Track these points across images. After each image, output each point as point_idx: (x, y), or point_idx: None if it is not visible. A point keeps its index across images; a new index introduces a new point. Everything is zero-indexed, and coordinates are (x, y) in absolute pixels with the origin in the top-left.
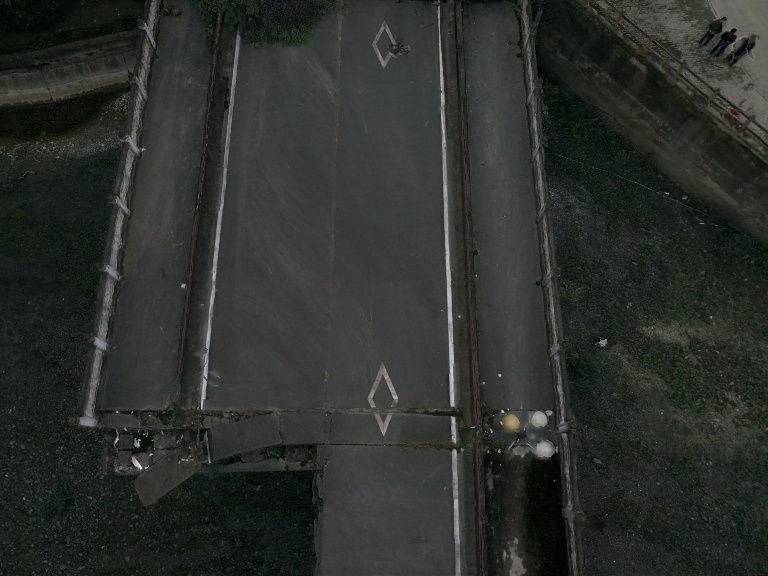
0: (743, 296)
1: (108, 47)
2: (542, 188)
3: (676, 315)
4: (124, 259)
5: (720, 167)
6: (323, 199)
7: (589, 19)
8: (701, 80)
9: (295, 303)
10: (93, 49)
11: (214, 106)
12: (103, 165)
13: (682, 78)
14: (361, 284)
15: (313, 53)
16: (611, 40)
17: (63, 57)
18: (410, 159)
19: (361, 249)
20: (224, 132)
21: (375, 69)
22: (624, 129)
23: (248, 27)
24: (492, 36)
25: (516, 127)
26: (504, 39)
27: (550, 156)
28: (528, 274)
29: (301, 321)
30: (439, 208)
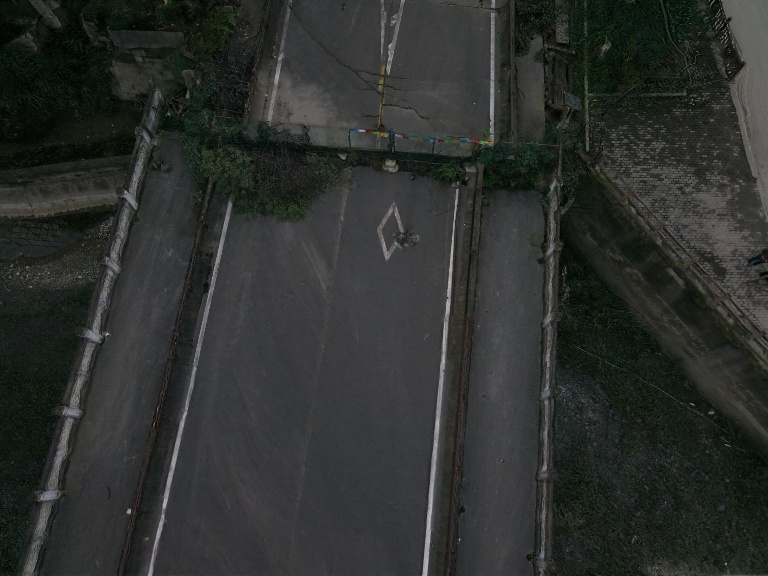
0: (765, 542)
1: (98, 170)
2: (547, 445)
3: (686, 556)
4: (68, 469)
5: (756, 399)
6: (298, 420)
7: (626, 218)
8: (745, 317)
9: (251, 549)
10: (81, 171)
11: (191, 292)
12: (76, 304)
13: (724, 306)
14: (328, 535)
15: (310, 233)
16: (648, 245)
17: (48, 177)
18: (402, 380)
19: (333, 489)
20: (199, 321)
21: (377, 261)
22: (652, 329)
23: (241, 196)
24: (513, 233)
25: (527, 353)
26: (526, 238)
27: (566, 347)
28: (519, 545)
29: (254, 573)
30: (427, 447)
